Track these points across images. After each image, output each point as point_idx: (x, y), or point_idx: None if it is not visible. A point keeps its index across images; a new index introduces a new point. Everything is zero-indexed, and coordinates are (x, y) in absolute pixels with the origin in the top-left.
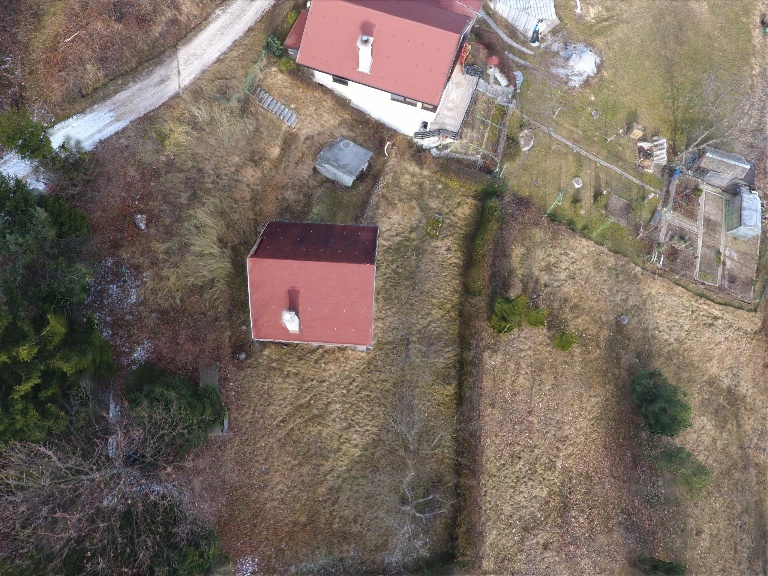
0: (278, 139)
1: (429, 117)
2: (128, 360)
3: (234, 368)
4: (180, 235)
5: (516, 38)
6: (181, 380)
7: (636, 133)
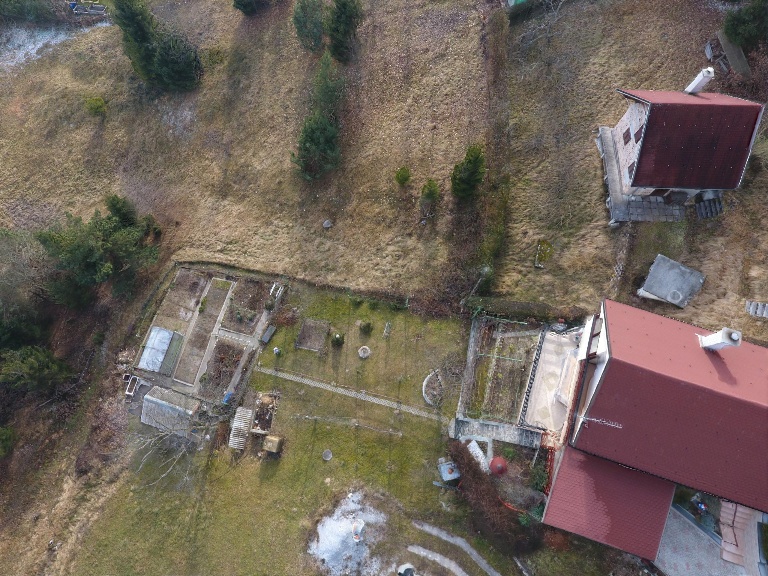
0: (759, 285)
1: None
2: None
3: (715, 89)
4: None
5: (437, 570)
6: None
7: (274, 438)
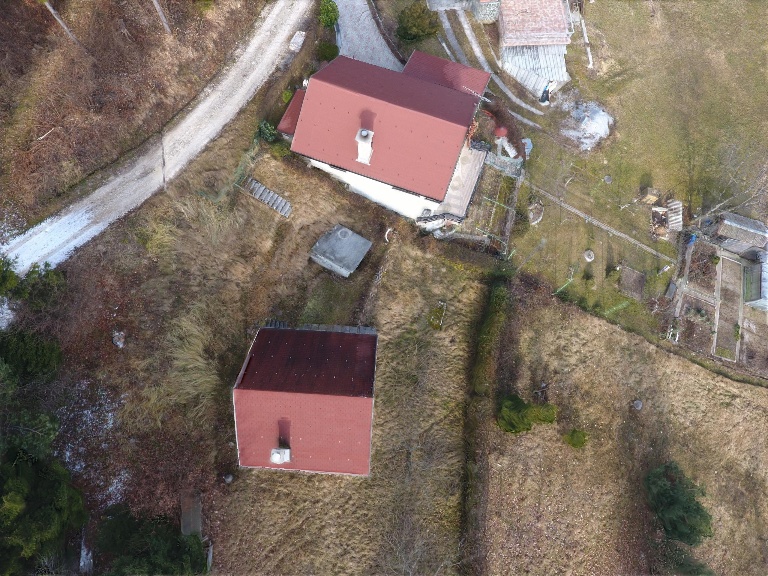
0: (271, 231)
1: (433, 206)
2: (103, 495)
3: (220, 493)
4: (162, 348)
5: (525, 98)
6: (158, 531)
7: (651, 198)
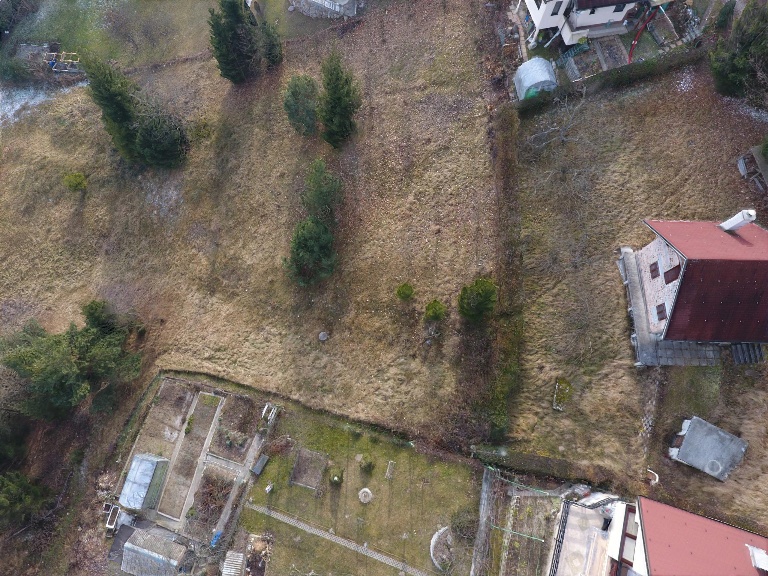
0: None
1: None
2: None
3: None
4: None
5: None
6: None
7: None
